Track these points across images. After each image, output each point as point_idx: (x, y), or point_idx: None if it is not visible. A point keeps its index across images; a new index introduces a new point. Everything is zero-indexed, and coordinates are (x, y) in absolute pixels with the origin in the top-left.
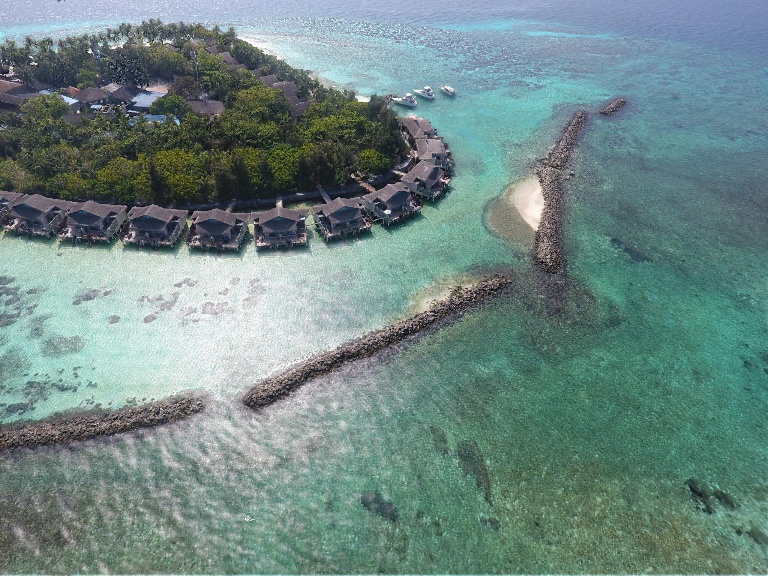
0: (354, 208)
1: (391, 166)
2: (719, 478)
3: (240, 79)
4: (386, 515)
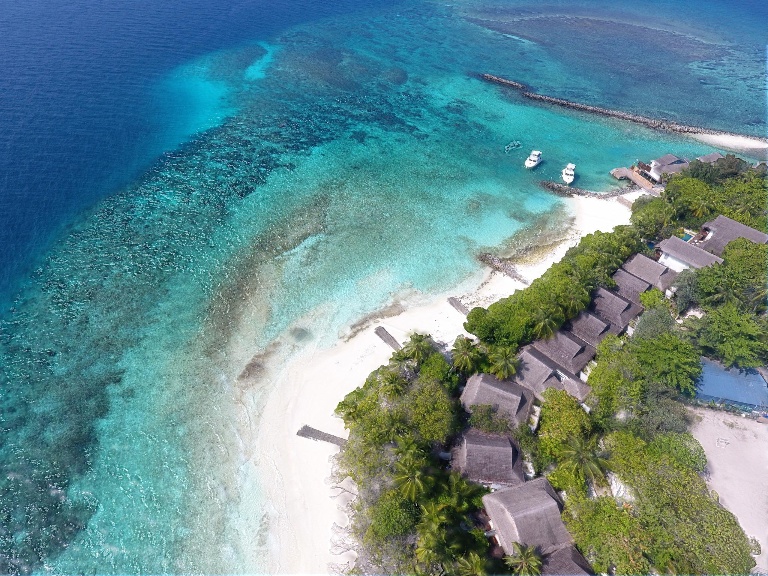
0: None
1: None
2: None
3: None
4: None
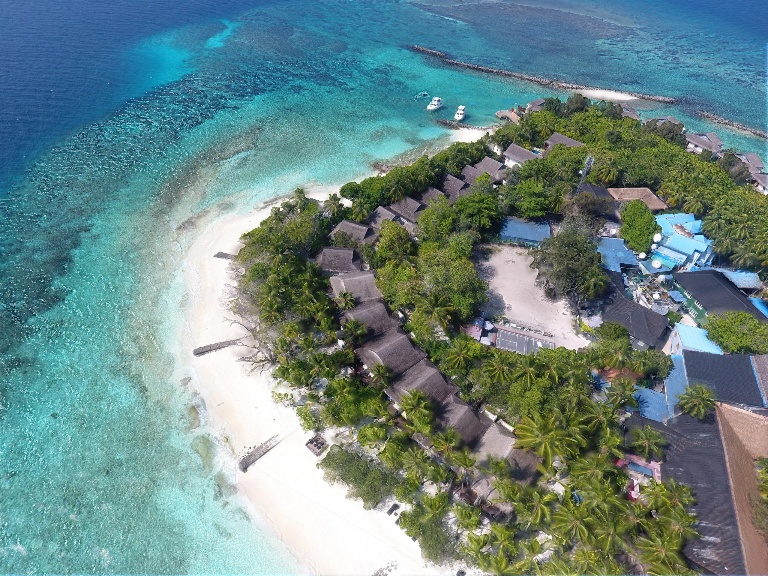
0: None
1: None
2: (765, 96)
3: None
4: None
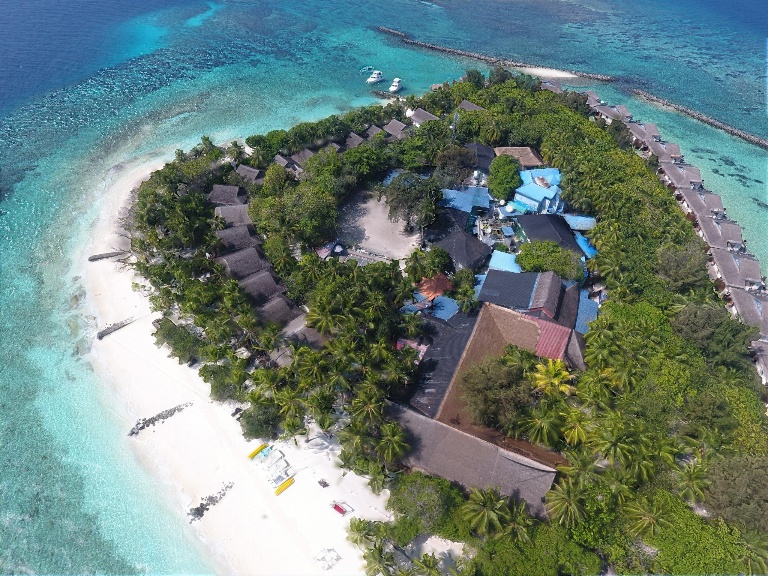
0: None
1: None
2: None
3: None
4: None
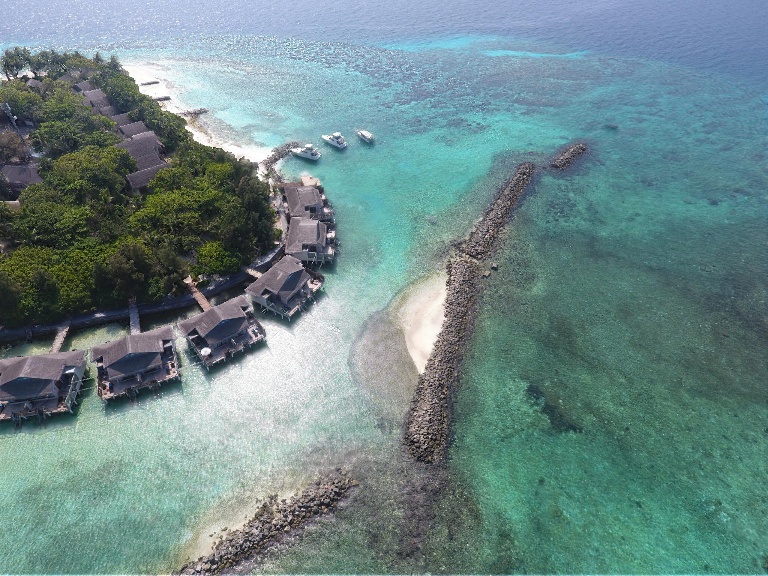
0: (149, 352)
1: (246, 262)
2: None
3: (99, 127)
4: None
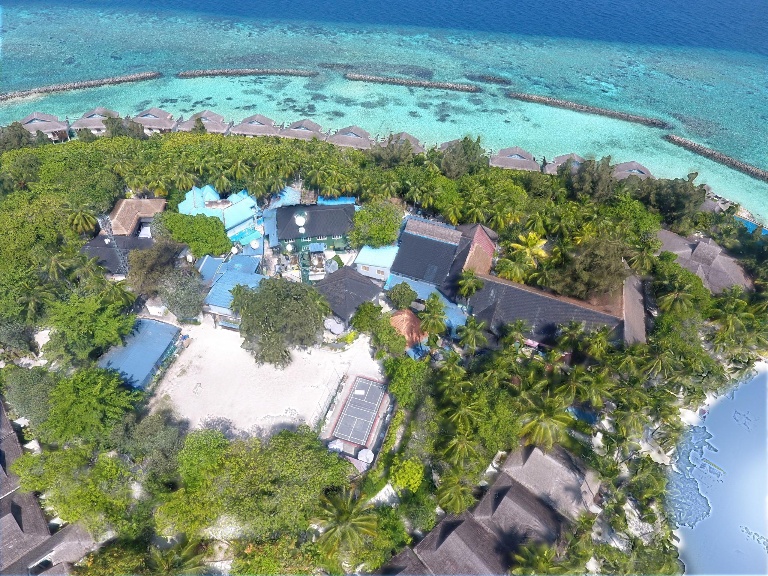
0: None
1: None
2: None
3: None
4: (115, 56)
